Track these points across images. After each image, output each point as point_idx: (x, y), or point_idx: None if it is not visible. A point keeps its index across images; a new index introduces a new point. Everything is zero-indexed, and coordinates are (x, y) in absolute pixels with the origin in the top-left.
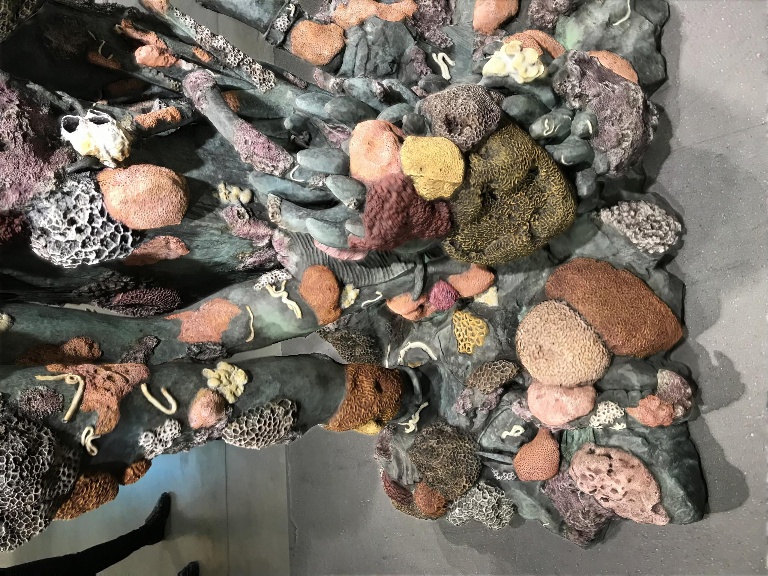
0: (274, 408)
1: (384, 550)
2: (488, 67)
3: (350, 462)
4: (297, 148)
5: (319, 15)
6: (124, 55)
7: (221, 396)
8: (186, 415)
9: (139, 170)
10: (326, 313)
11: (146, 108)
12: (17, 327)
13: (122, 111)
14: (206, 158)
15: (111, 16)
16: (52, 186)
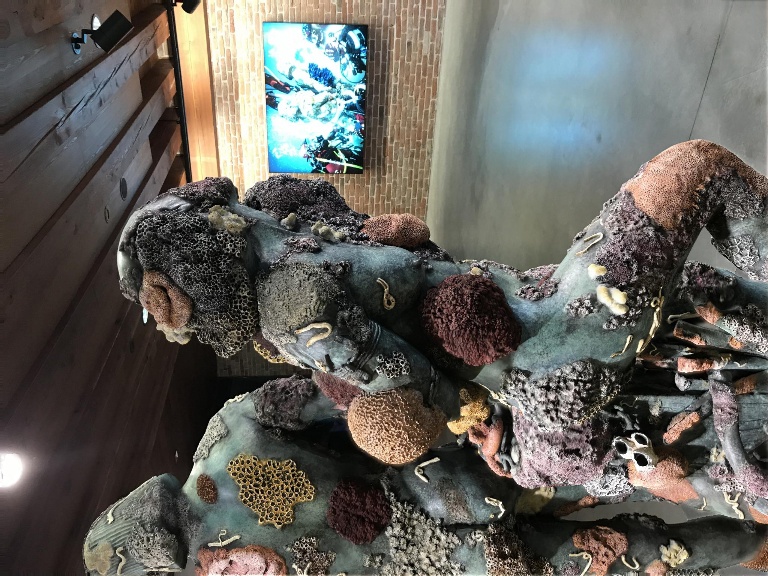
0: (700, 573)
1: None
2: None
3: None
4: None
5: None
6: (668, 351)
7: (668, 565)
8: (643, 569)
9: (657, 471)
10: (764, 523)
11: (673, 362)
12: (557, 495)
13: (655, 399)
14: (709, 425)
15: (666, 306)
16: (600, 479)
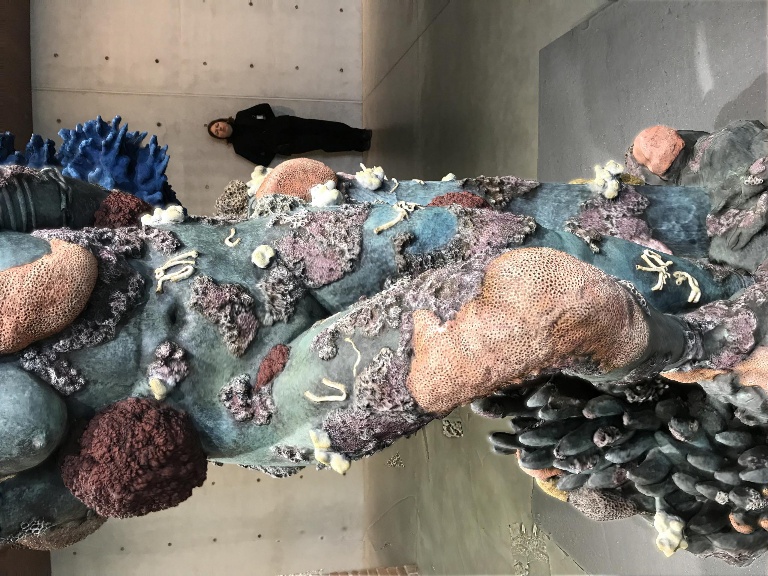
0: None
1: (584, 167)
2: (656, 521)
3: (623, 113)
4: None
5: (723, 359)
6: None
7: None
8: None
9: None
10: None
11: None
12: None
13: None
14: None
15: None
16: None
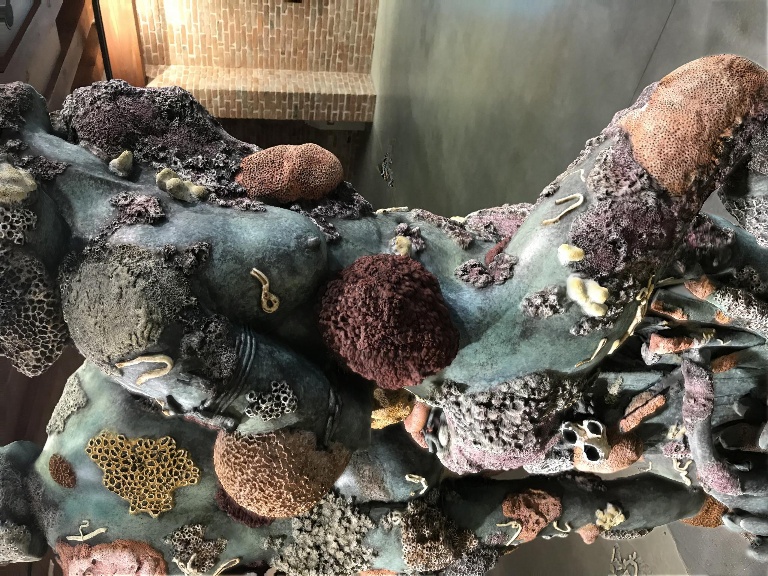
0: (634, 533)
1: None
2: None
3: None
4: (765, 421)
5: None
6: None
7: (602, 529)
8: None
9: (608, 458)
10: None
11: None
12: None
13: (616, 376)
14: (673, 402)
15: None
16: None
